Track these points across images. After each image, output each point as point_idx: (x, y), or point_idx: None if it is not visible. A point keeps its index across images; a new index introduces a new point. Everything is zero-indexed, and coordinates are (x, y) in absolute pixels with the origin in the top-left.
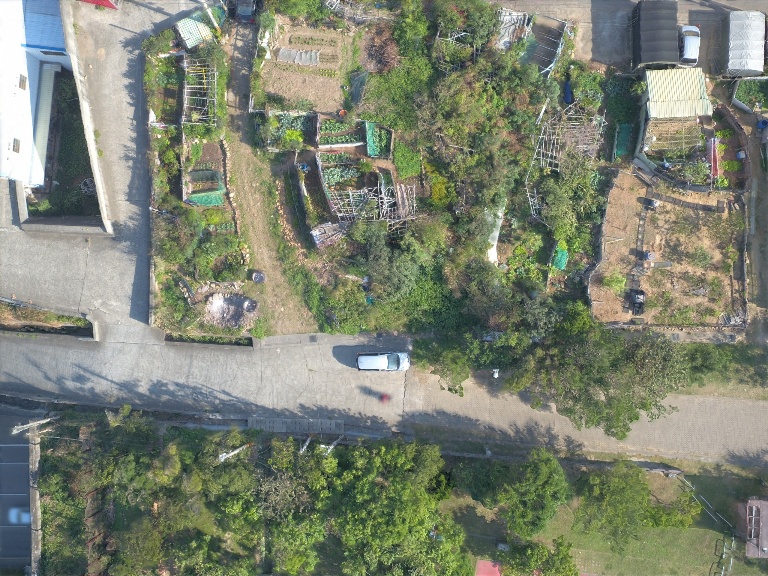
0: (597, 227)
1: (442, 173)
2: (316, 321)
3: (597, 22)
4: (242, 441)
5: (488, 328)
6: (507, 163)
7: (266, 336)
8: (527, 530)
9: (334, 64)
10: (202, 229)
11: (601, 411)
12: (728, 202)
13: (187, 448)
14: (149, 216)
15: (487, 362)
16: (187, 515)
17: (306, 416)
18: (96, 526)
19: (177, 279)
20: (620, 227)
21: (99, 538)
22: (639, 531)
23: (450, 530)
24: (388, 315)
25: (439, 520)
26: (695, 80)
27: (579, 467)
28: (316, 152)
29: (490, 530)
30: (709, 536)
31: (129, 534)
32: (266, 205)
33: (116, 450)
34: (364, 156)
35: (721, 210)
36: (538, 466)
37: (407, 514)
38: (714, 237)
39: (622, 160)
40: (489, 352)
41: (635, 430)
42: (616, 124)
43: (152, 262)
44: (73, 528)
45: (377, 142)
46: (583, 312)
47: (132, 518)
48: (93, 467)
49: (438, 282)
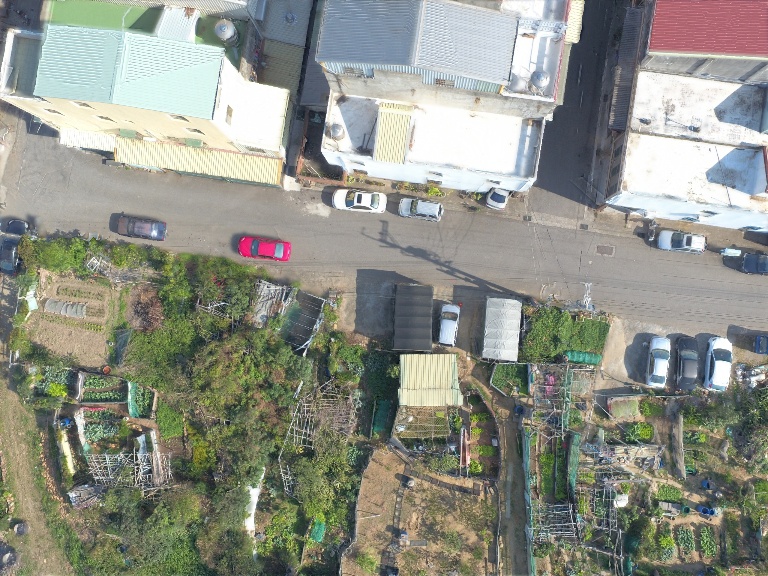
0: (353, 503)
1: None
2: (77, 575)
3: (362, 293)
4: None
5: None
6: (261, 439)
7: None
8: None
9: (100, 318)
10: None
11: None
12: (484, 485)
13: None
14: None
15: None
16: None
17: None
18: None
19: None
20: (377, 503)
21: None
22: None
23: None
24: None
25: None
26: (448, 368)
27: None
28: None
29: None
30: None
31: None
32: (31, 455)
33: None
34: (127, 414)
35: (476, 493)
36: None
37: None
38: (465, 524)
39: (380, 436)
40: None
41: None
42: (374, 401)
43: None
44: None
45: (140, 401)
46: None
47: None
48: None
49: (193, 550)
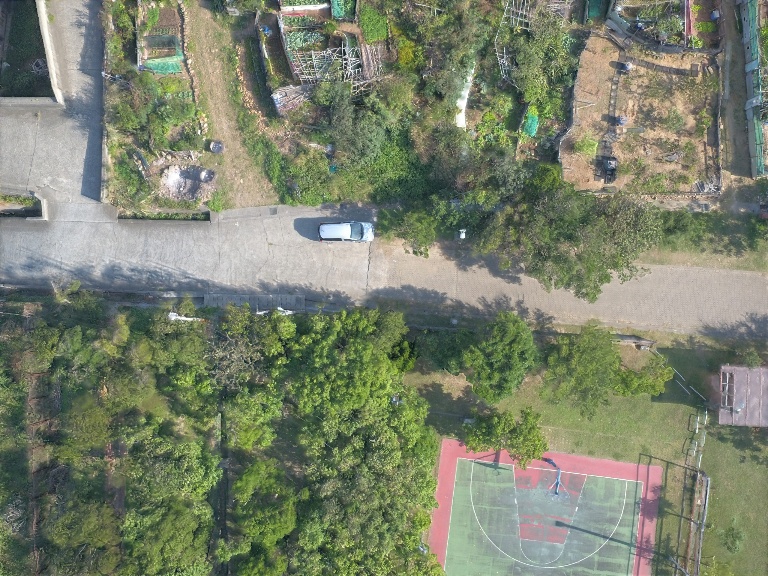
0: (568, 91)
1: (409, 36)
2: (277, 193)
3: None
4: (197, 315)
5: (455, 189)
6: (476, 22)
7: (224, 209)
8: (494, 395)
9: None
10: (157, 96)
11: (571, 266)
12: (702, 65)
13: (140, 327)
14: (102, 86)
15: (453, 223)
16: (137, 388)
17: (265, 292)
18: (42, 411)
19: (131, 152)
20: (592, 92)
21: (45, 424)
22: (610, 407)
23: (414, 401)
24: (352, 183)
25: (403, 391)
26: None
27: (549, 340)
28: (278, 14)
29: (457, 407)
30: (682, 411)
31: (75, 412)
32: (225, 72)
33: (63, 325)
34: (328, 19)
35: (695, 74)
36: (505, 325)
37: (368, 375)
38: (687, 99)
39: (594, 22)
40: (456, 212)
41: (607, 302)
42: None
43: (105, 133)
44: (18, 417)
45: (342, 4)
46: (553, 168)
47: (80, 402)
48: (37, 341)
49: (404, 148)
